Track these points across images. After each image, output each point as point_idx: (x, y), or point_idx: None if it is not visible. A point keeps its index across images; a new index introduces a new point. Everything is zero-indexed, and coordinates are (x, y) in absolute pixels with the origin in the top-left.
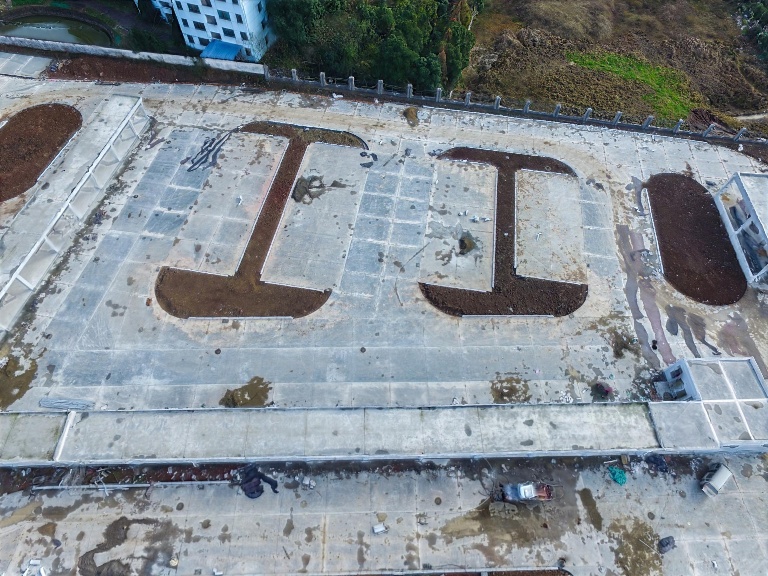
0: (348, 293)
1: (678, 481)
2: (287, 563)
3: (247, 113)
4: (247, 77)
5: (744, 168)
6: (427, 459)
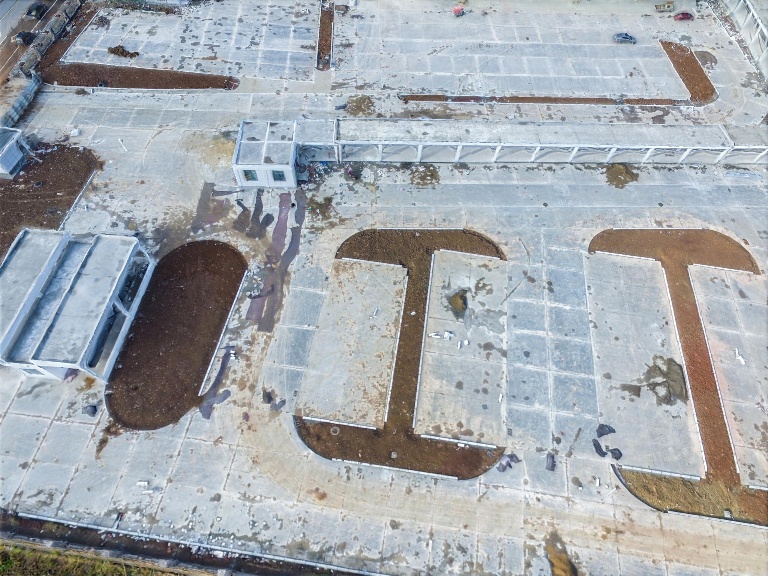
0: (573, 250)
1: None
2: (558, 108)
3: None
4: None
5: (5, 448)
6: None
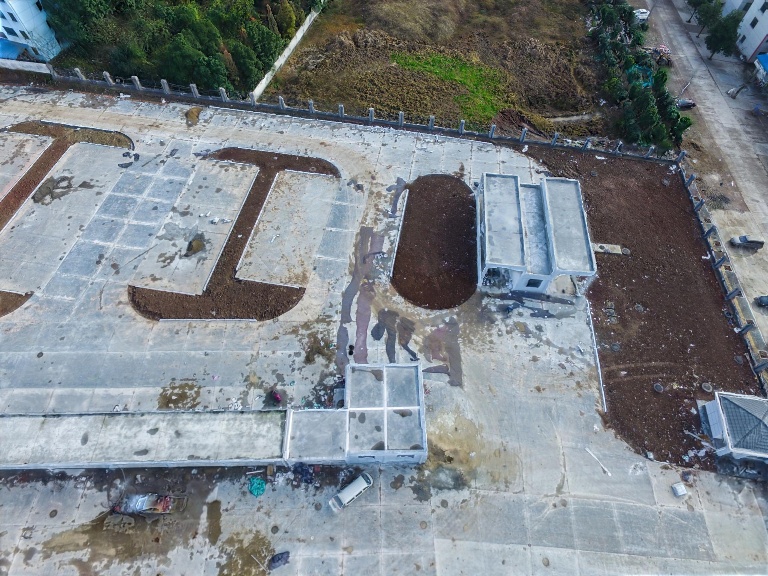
0: (49, 296)
1: (319, 493)
2: None
3: (21, 113)
4: (34, 77)
5: (520, 169)
6: (60, 469)
